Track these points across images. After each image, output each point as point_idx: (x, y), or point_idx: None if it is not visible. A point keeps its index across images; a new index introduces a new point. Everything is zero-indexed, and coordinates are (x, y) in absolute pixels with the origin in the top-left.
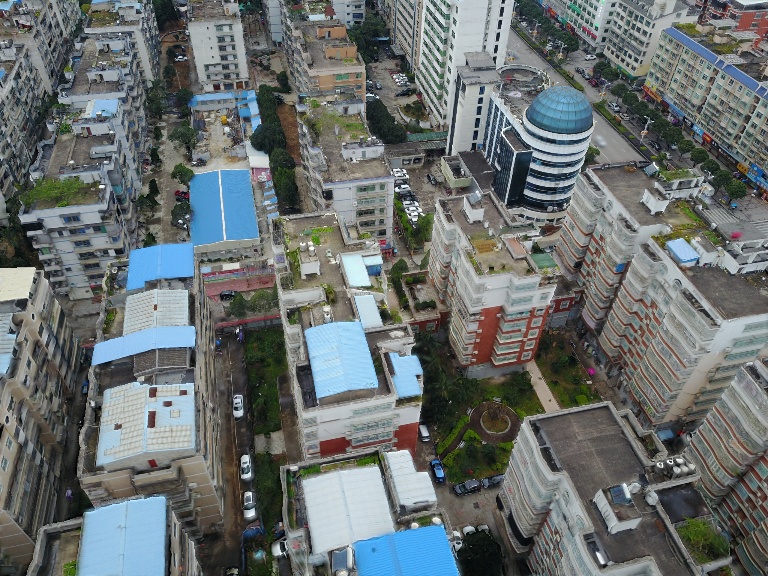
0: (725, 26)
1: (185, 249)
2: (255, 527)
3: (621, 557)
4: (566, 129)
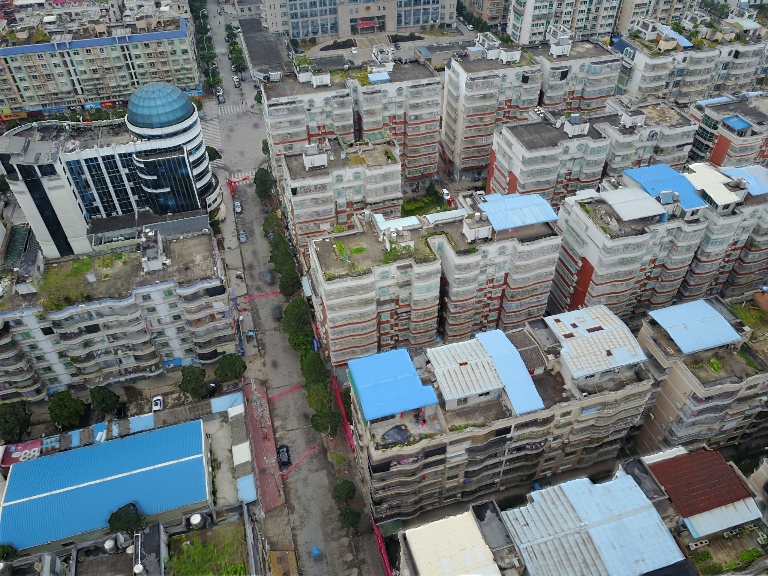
0: (4, 25)
1: (360, 365)
2: None
3: (597, 134)
4: (191, 108)
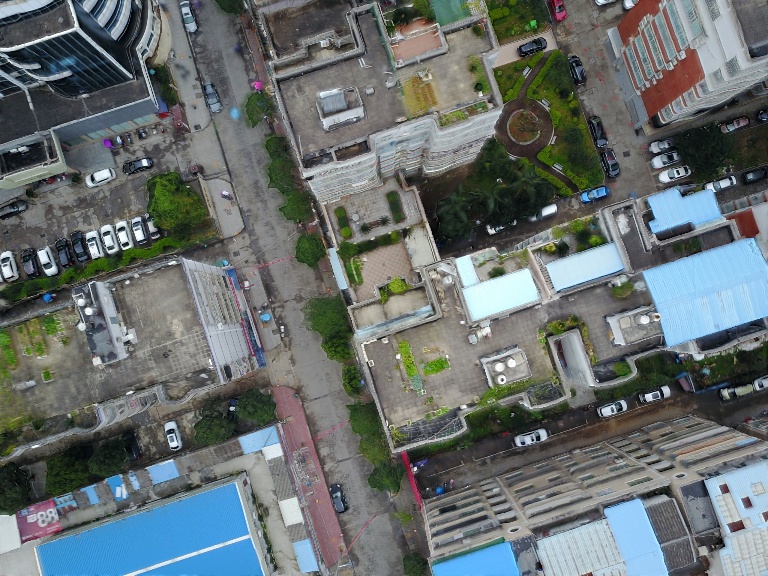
0: None
1: (450, 575)
2: (691, 381)
3: None
4: None
